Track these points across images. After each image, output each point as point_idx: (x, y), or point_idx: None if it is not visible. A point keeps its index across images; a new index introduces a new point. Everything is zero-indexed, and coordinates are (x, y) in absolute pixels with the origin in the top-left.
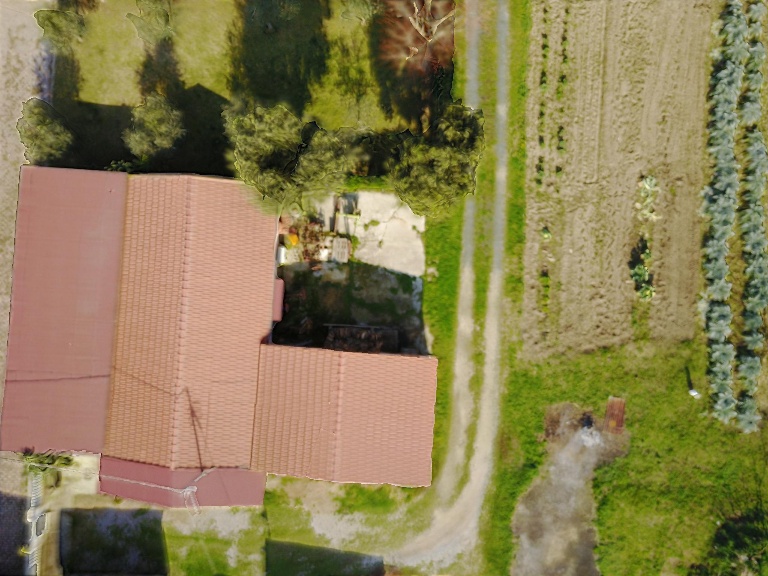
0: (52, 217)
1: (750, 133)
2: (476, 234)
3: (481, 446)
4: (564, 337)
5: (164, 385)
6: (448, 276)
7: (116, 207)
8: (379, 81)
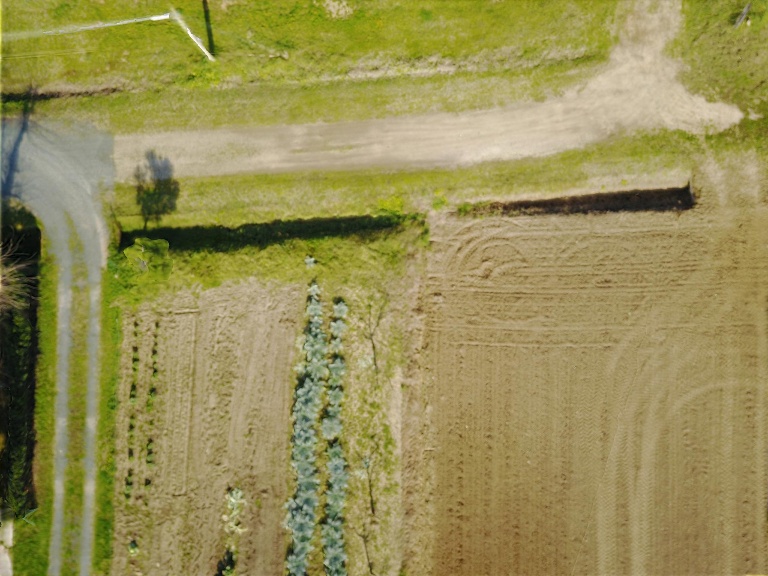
0: None
1: (329, 447)
2: (63, 549)
3: None
4: None
5: None
6: None
7: None
8: None
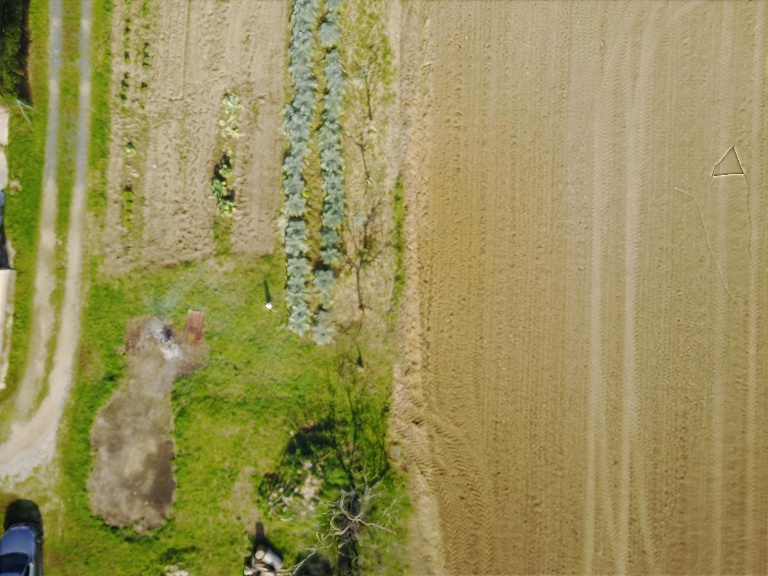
0: None
1: (328, 53)
2: (60, 148)
3: (60, 360)
4: (147, 252)
5: None
6: (30, 190)
7: None
8: None
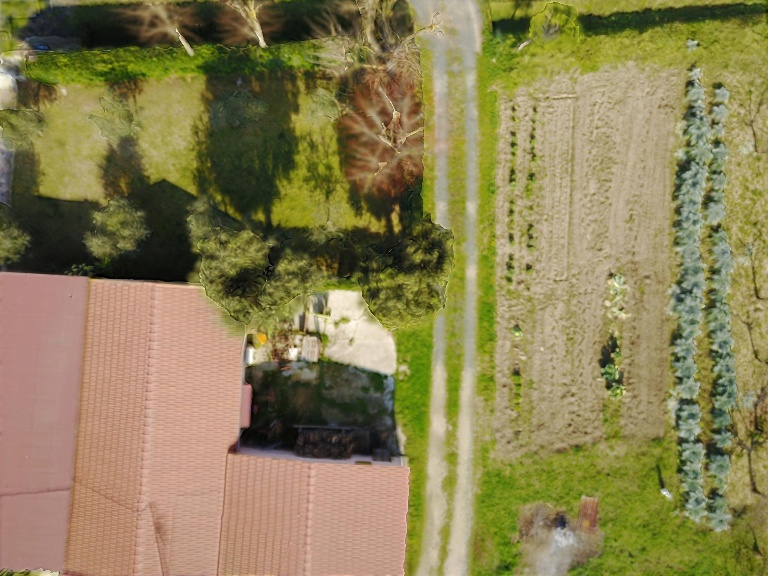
0: (9, 324)
1: (715, 232)
2: (447, 332)
3: (454, 549)
4: (536, 436)
5: (126, 501)
6: (420, 375)
7: (77, 313)
8: (349, 178)
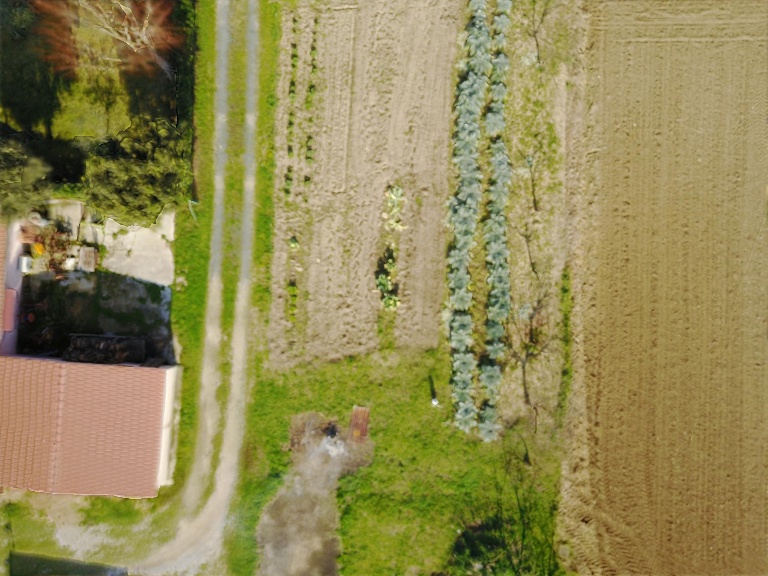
0: None
1: (493, 144)
2: (224, 243)
3: (227, 456)
4: (311, 346)
5: None
6: (196, 285)
7: None
8: (129, 89)
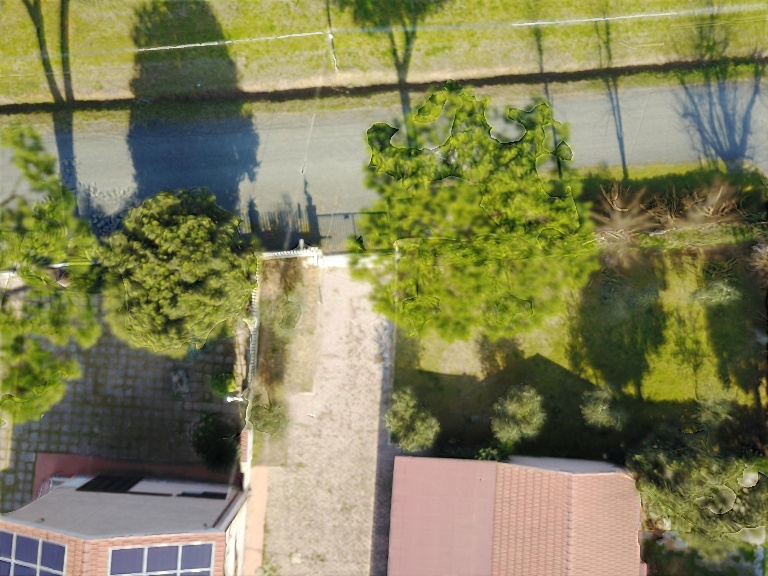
0: (425, 506)
1: None
2: None
3: None
4: None
5: None
6: None
7: (487, 496)
8: (715, 351)
